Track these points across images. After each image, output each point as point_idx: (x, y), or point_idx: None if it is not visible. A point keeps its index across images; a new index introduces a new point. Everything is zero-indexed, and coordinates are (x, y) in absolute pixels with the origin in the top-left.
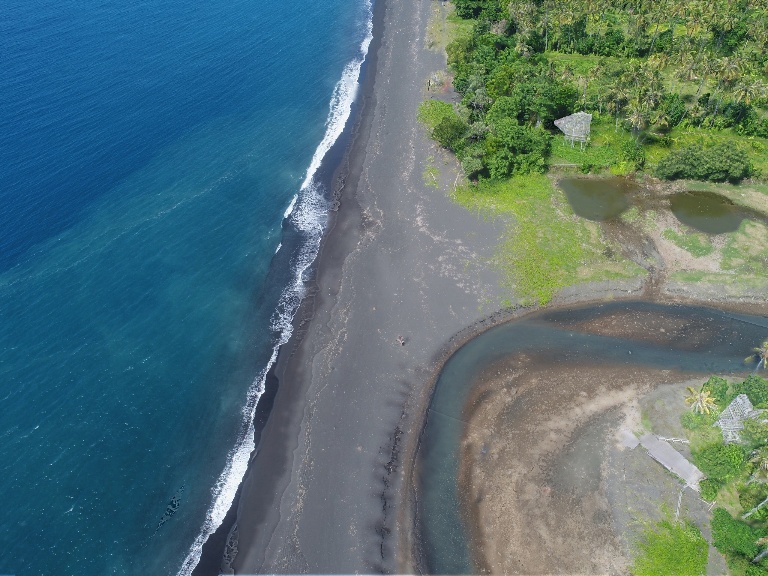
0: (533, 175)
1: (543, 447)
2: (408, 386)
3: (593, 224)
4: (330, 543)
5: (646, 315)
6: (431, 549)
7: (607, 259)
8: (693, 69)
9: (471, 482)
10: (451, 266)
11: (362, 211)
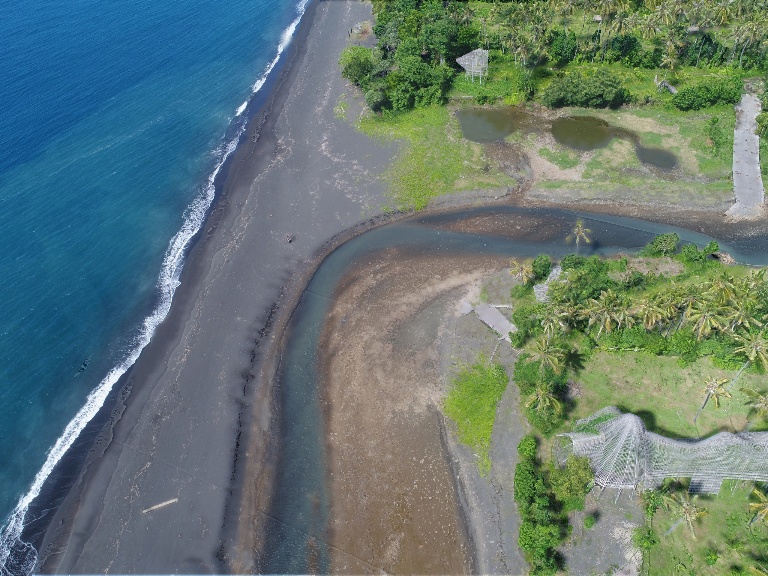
0: (433, 107)
1: (394, 316)
2: (289, 273)
3: (478, 145)
4: (203, 384)
5: (507, 216)
6: (286, 390)
7: (484, 173)
8: (574, 5)
9: (329, 342)
10: (344, 181)
11: (277, 141)
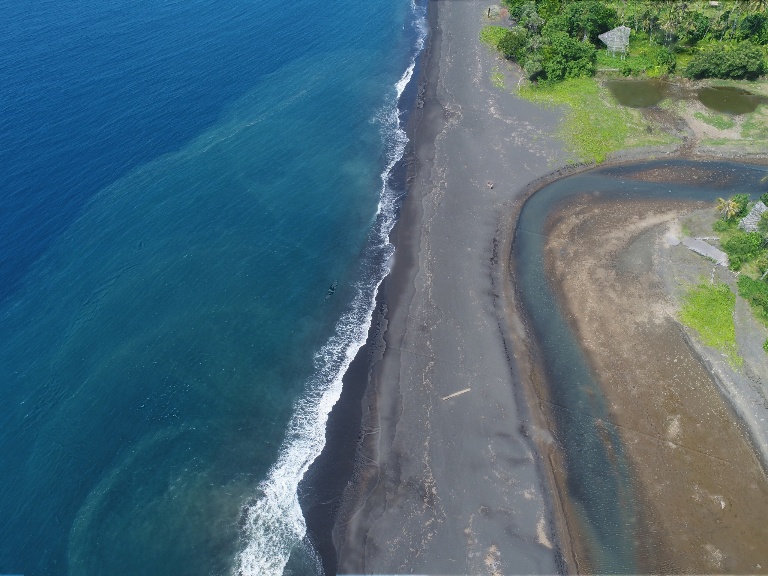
0: (582, 78)
1: (607, 248)
2: (499, 214)
3: (635, 110)
4: (457, 301)
5: (682, 168)
6: (530, 306)
7: (648, 133)
8: None
9: (555, 269)
10: (523, 139)
11: (443, 106)
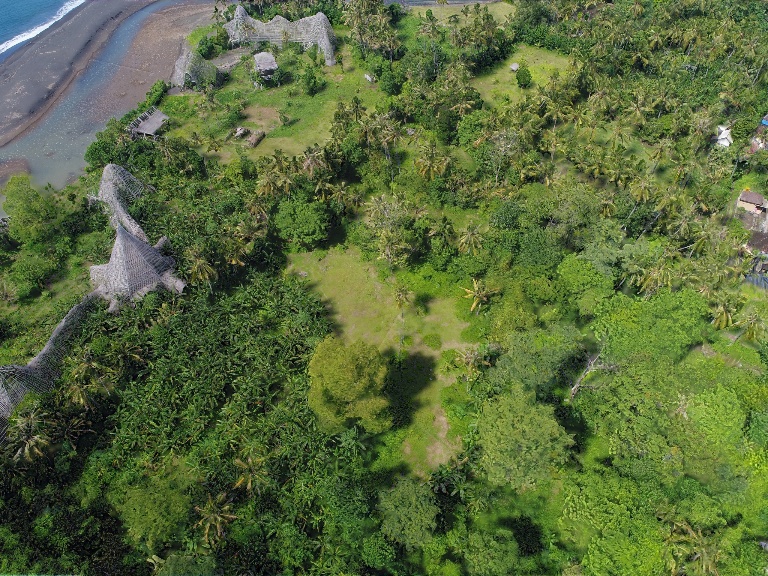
0: None
1: None
2: (133, 4)
3: None
4: None
5: None
6: (117, 34)
7: None
8: None
9: (144, 23)
10: None
11: None
